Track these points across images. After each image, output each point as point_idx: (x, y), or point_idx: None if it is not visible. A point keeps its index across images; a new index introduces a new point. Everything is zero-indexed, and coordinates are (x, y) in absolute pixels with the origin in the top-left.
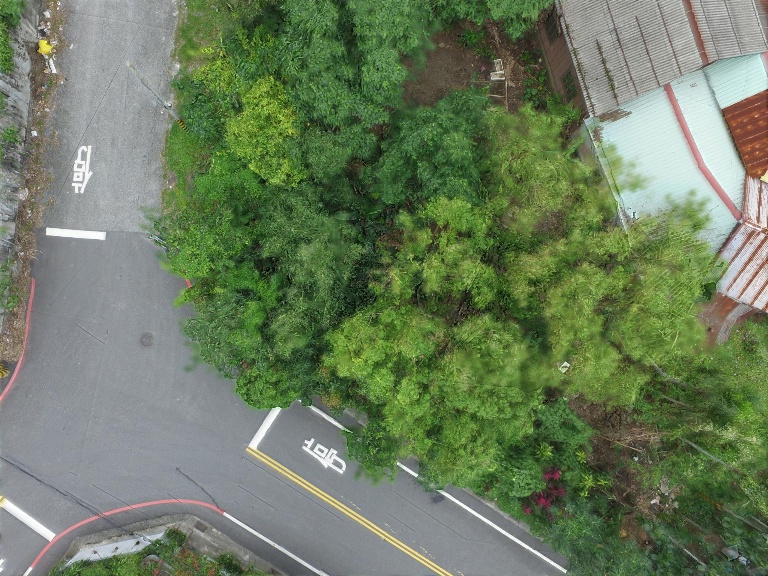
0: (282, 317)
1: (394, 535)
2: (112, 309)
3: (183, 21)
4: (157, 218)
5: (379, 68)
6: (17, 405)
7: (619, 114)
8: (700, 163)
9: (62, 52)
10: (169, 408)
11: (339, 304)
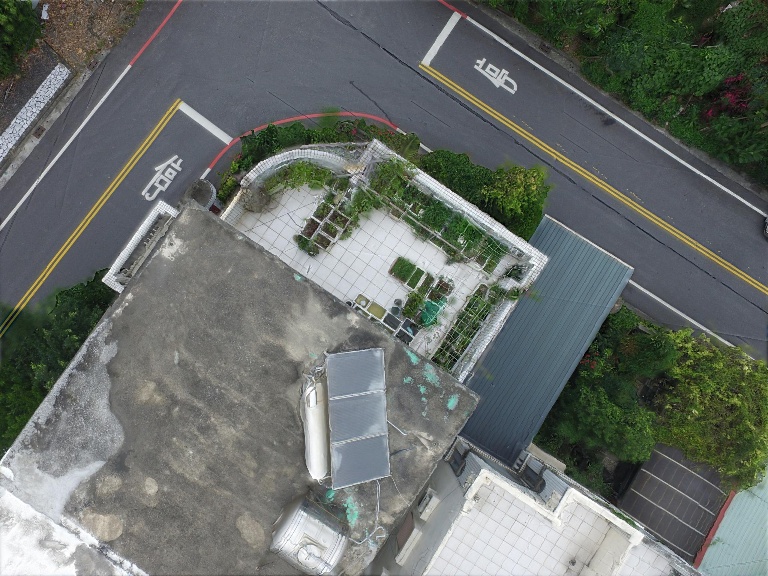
0: None
1: (566, 155)
2: None
3: None
4: None
5: None
6: (193, 13)
7: None
8: None
9: None
10: None
11: None
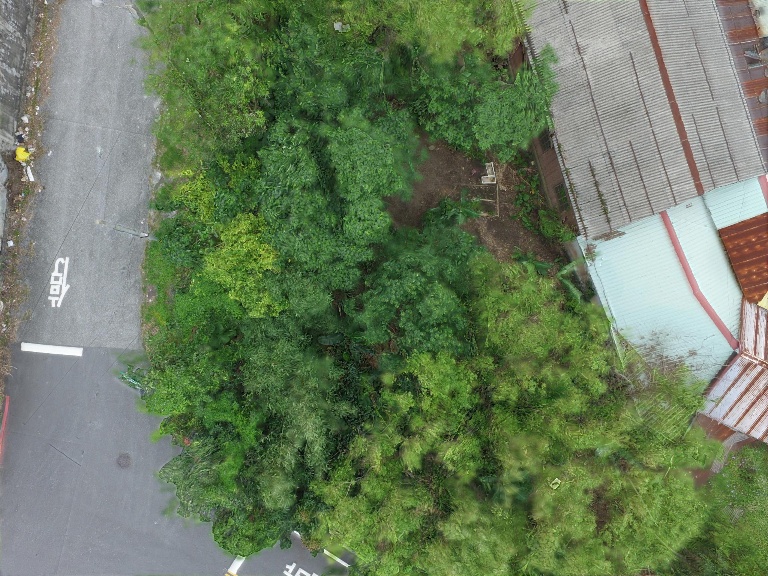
0: (261, 457)
1: None
2: (88, 429)
3: (165, 127)
4: (136, 333)
5: (361, 218)
6: None
7: (612, 234)
8: (695, 290)
9: (40, 159)
10: (146, 532)
11: (320, 441)
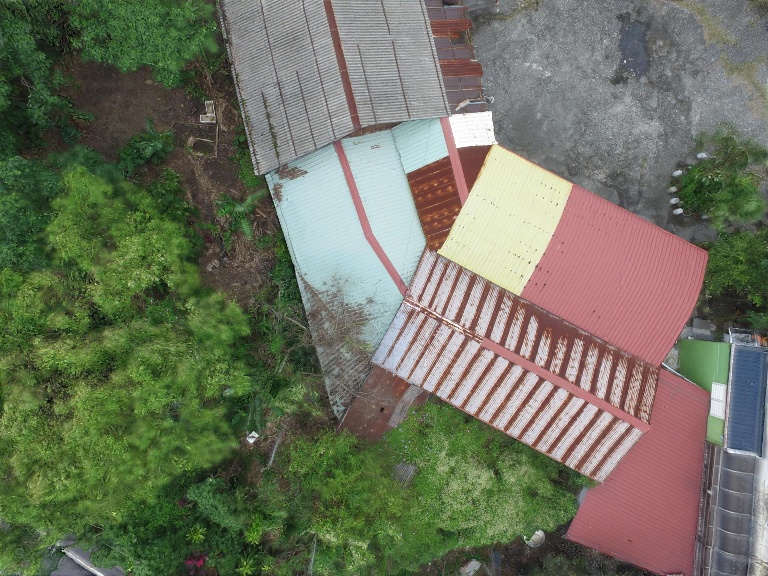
0: None
1: None
2: None
3: None
4: None
5: None
6: None
7: (295, 173)
8: (366, 232)
9: None
10: None
11: None
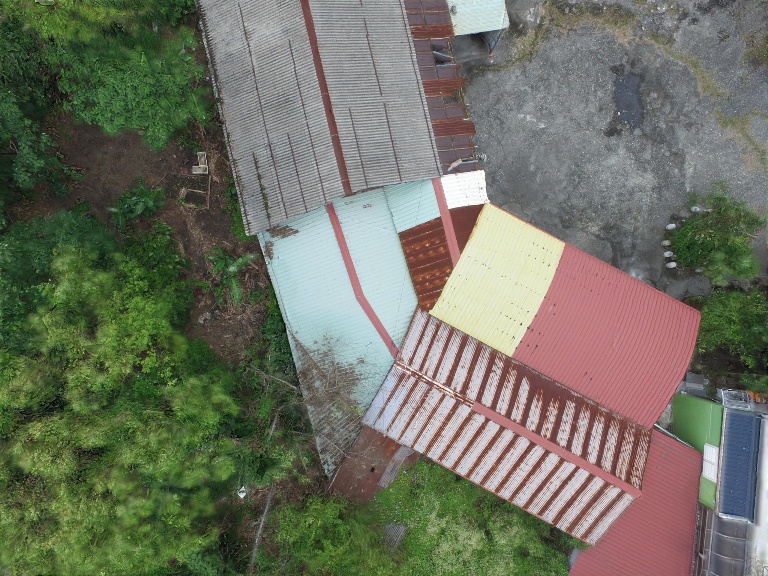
0: None
1: None
2: None
3: None
4: None
5: None
6: None
7: (287, 231)
8: (357, 294)
9: None
10: None
11: None
